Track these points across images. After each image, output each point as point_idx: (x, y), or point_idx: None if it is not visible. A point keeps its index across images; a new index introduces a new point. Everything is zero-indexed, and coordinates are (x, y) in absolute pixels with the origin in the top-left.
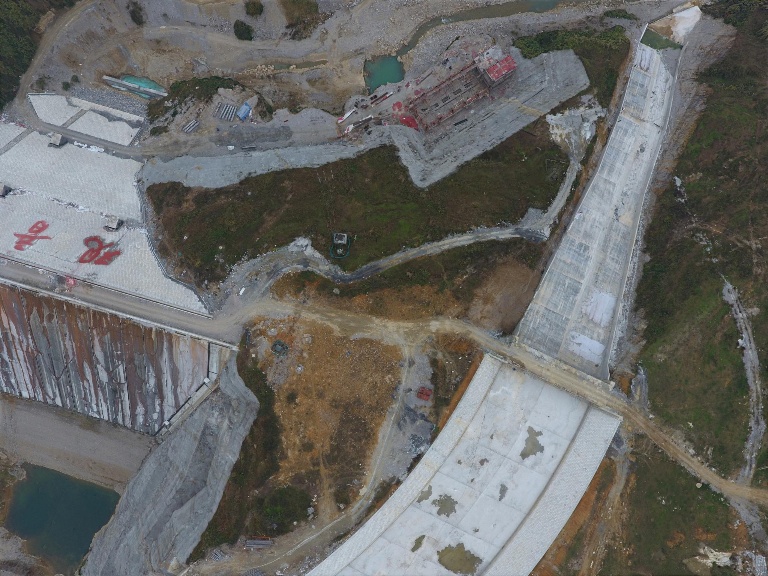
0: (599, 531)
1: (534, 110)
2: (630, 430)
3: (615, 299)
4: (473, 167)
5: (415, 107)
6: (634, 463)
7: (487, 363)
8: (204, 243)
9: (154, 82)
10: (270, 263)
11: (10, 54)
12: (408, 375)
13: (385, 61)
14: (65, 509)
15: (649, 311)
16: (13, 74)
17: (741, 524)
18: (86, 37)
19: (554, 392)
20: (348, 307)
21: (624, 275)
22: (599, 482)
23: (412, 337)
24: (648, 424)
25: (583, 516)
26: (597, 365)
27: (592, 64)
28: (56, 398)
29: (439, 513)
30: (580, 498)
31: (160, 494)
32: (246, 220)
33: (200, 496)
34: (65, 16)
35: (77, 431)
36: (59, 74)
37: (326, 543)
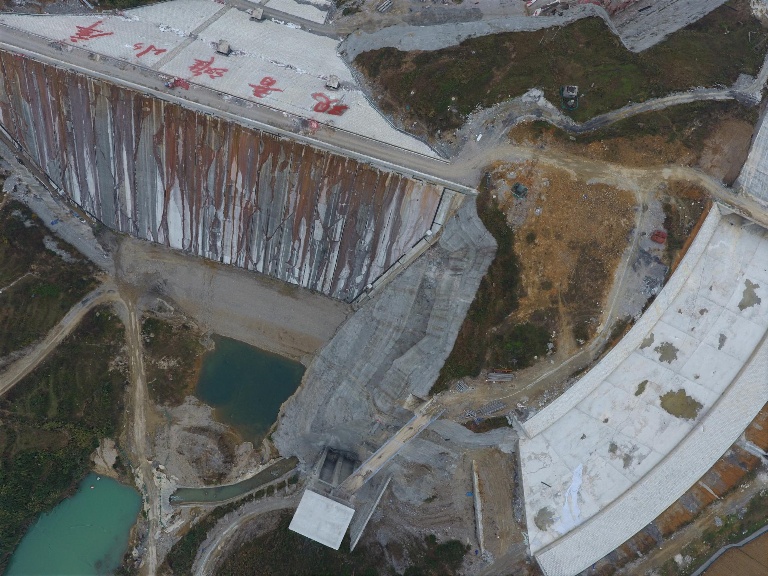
0: None
1: None
2: None
3: None
4: (682, 36)
5: None
6: None
7: (714, 212)
8: (437, 94)
9: None
10: (505, 112)
11: None
12: (642, 219)
13: None
14: (251, 381)
15: None
16: None
17: None
18: None
19: None
20: (584, 153)
21: None
22: None
23: (645, 183)
24: None
25: None
26: None
27: None
28: (259, 263)
29: (661, 360)
30: None
31: (372, 349)
32: (475, 74)
33: (425, 342)
34: None
35: (275, 297)
36: None
37: (565, 378)
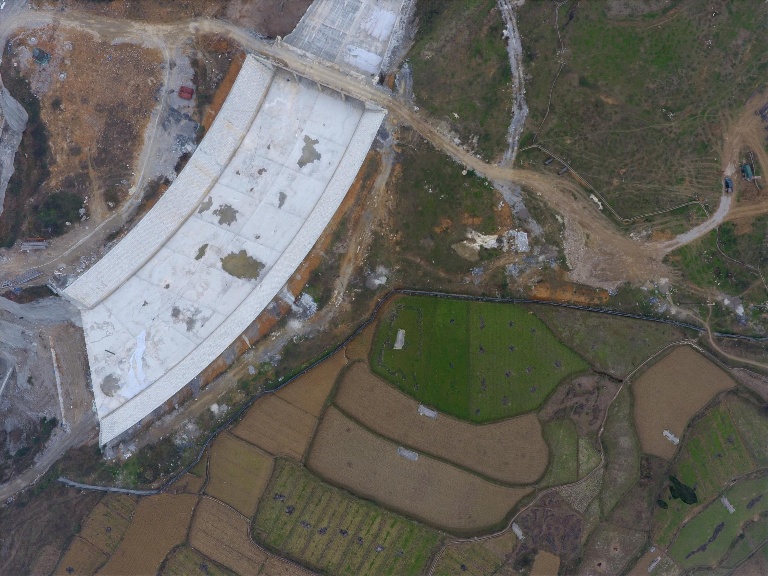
0: (365, 218)
1: None
2: (395, 123)
3: (396, 16)
4: None
5: None
6: (400, 154)
7: (252, 66)
8: None
9: None
10: None
11: None
12: (170, 77)
13: None
14: None
15: (422, 16)
16: None
17: (505, 205)
18: None
19: (329, 101)
20: (106, 12)
21: None
22: (364, 172)
23: (172, 39)
24: (413, 116)
25: (348, 204)
26: (373, 74)
27: None
28: None
29: (220, 222)
30: (347, 190)
31: None
32: None
33: None
34: None
35: None
36: None
37: (100, 242)
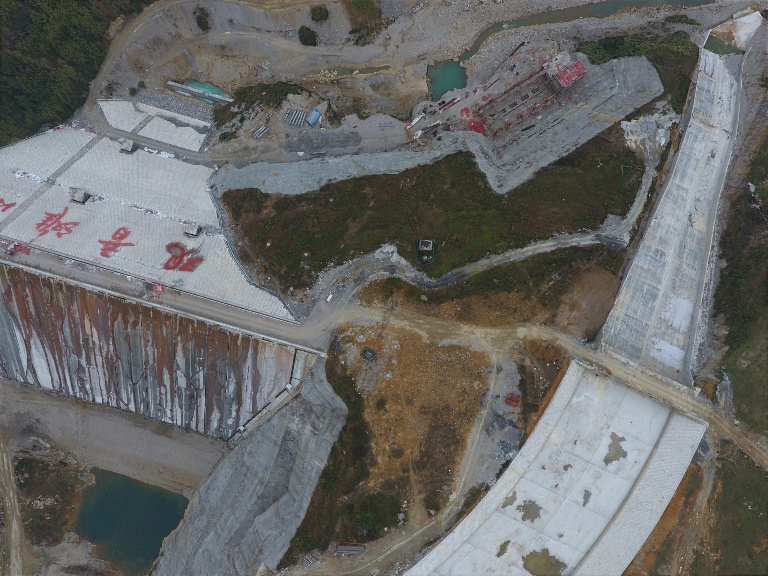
0: (687, 537)
1: (607, 116)
2: (716, 436)
3: (693, 305)
4: (551, 173)
5: (483, 113)
6: (720, 469)
7: (573, 369)
8: (289, 250)
9: (218, 87)
10: (356, 270)
11: (82, 60)
12: (496, 381)
13: (447, 66)
14: (133, 514)
15: (730, 317)
16: (84, 80)
17: None
18: (153, 43)
19: (636, 398)
20: (436, 314)
21: (701, 281)
22: (686, 488)
23: (500, 343)
24: (734, 430)
25: (671, 522)
26: (678, 371)
27: (665, 70)
28: (130, 403)
29: (524, 518)
30: (667, 504)
31: (239, 499)
32: (330, 227)
33: (284, 502)
34: (133, 22)
35: (150, 436)
36: (127, 80)
37: (416, 549)
